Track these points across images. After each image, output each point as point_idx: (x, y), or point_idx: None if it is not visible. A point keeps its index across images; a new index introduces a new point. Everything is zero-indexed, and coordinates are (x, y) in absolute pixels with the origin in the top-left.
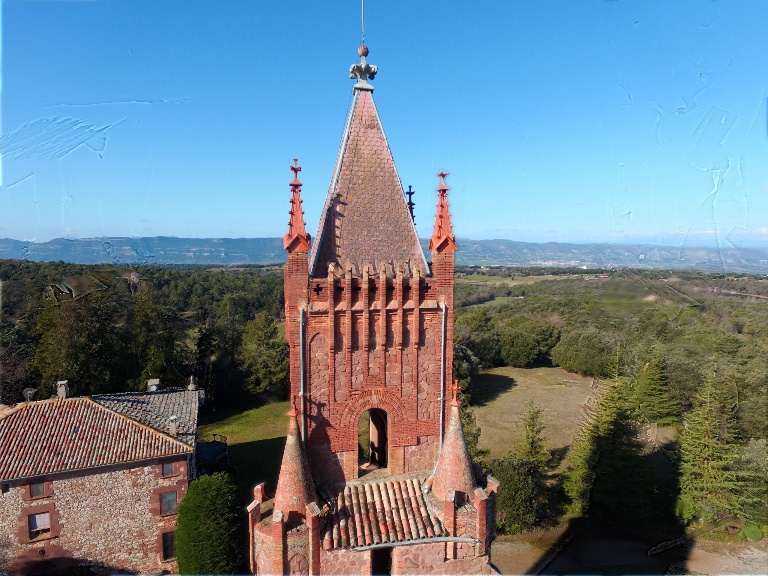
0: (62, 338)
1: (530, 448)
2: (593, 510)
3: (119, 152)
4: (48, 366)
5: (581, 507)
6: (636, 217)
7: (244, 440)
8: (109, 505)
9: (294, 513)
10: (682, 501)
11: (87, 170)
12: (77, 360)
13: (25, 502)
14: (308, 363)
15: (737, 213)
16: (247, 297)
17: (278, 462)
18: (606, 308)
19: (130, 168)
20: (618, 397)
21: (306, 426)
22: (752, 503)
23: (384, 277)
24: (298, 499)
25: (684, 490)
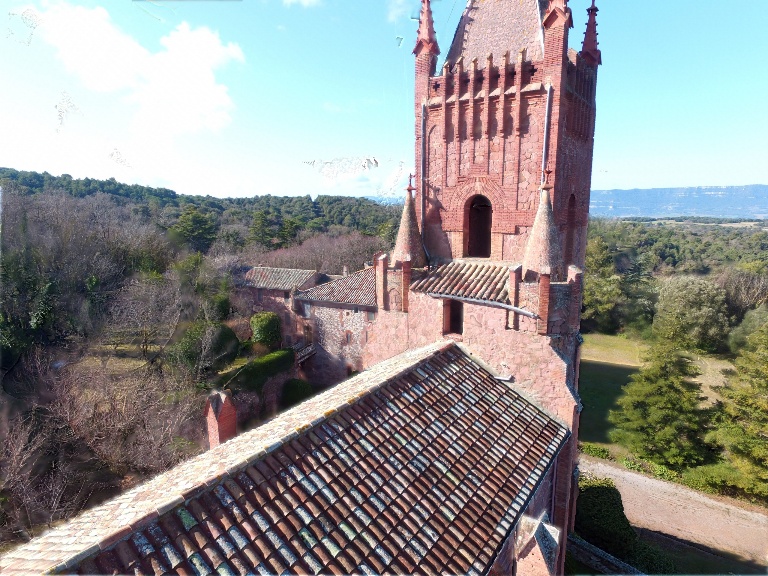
0: None
1: None
2: None
3: None
4: None
5: None
6: None
7: None
8: None
9: (399, 262)
10: None
11: None
12: None
13: (365, 322)
14: (427, 152)
15: None
16: None
17: None
18: None
19: None
20: None
21: (425, 206)
22: None
23: (488, 64)
24: (403, 253)
25: None
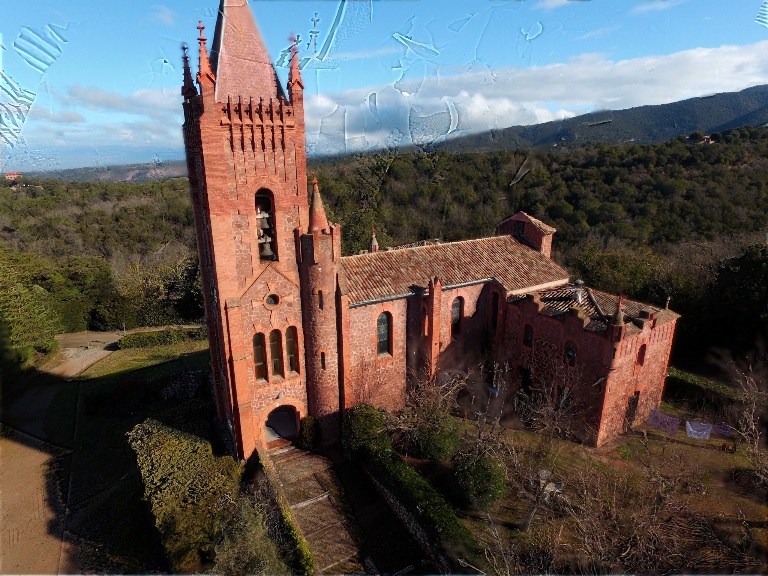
0: None
1: None
2: None
3: None
4: None
5: None
6: None
7: None
8: None
9: None
10: (20, 348)
11: None
12: None
13: None
14: None
15: None
16: None
17: None
18: None
19: None
20: None
21: None
22: None
23: None
24: None
25: (15, 340)
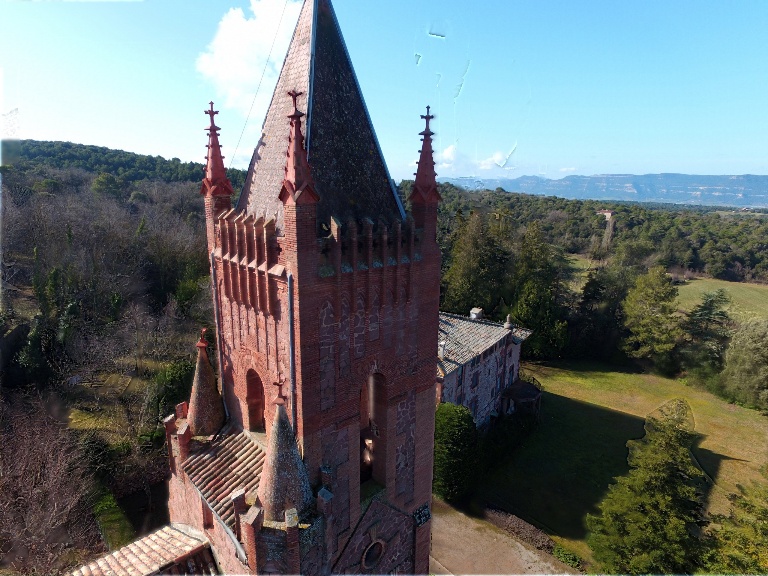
0: (462, 260)
1: None
2: None
3: (496, 94)
4: (453, 280)
5: None
6: None
7: (585, 398)
8: None
9: None
10: None
11: (470, 115)
12: (469, 280)
13: None
14: (220, 305)
15: None
16: (648, 247)
17: (595, 435)
18: None
19: (506, 108)
20: None
21: (223, 361)
22: None
23: (245, 230)
24: (190, 416)
25: None
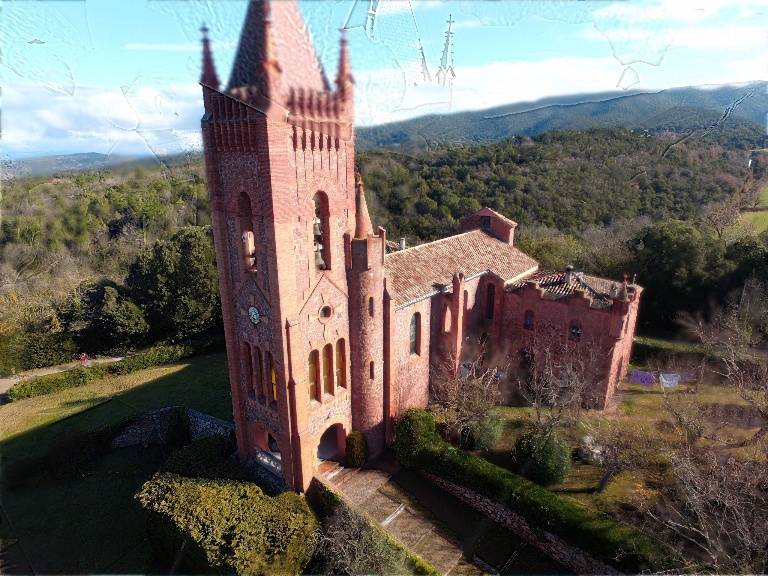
0: None
1: None
2: None
3: None
4: None
5: None
6: None
7: None
8: None
9: None
10: None
11: None
12: None
13: None
14: None
15: None
16: None
17: None
18: None
19: None
20: None
21: None
22: None
23: None
24: None
25: None
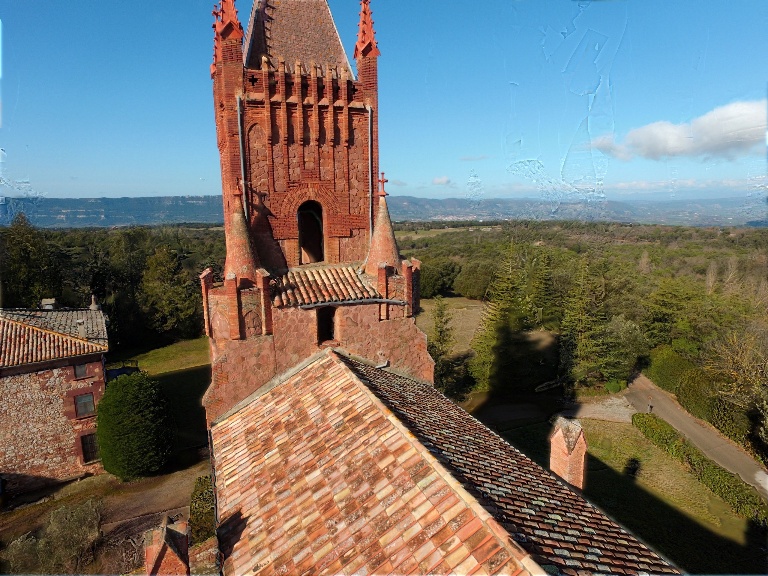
0: None
1: (439, 336)
2: (492, 384)
3: None
4: None
5: (482, 385)
6: (526, 149)
7: (155, 372)
8: (16, 410)
9: (245, 280)
10: (562, 368)
11: None
12: None
13: None
14: (247, 152)
15: (606, 125)
16: (144, 232)
17: (196, 385)
18: (502, 204)
19: None
20: (512, 287)
21: (249, 213)
22: (613, 364)
23: (315, 73)
24: (248, 268)
25: (563, 359)
